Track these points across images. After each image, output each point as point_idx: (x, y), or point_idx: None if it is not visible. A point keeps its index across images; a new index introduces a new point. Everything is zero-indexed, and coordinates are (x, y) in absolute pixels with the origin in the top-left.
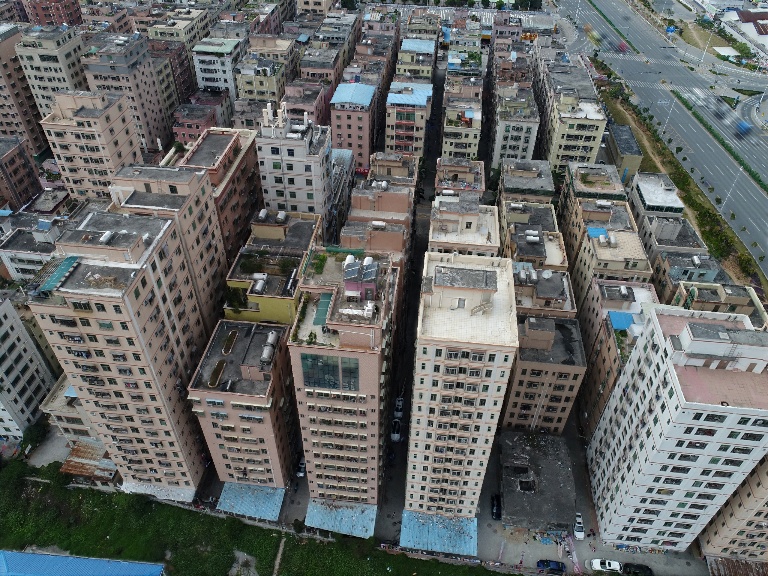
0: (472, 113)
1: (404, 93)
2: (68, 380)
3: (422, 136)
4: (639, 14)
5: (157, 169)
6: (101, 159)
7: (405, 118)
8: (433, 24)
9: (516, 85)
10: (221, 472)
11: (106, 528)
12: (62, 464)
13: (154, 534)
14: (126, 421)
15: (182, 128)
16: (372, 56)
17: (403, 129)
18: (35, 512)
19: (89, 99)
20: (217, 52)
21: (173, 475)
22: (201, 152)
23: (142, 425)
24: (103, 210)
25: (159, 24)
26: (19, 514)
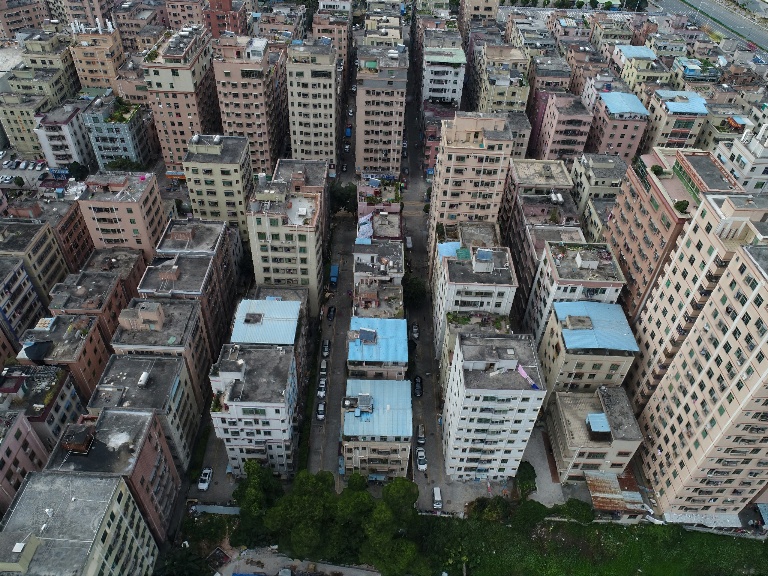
0: (741, 119)
1: (681, 101)
2: (567, 414)
3: (693, 143)
4: (738, 13)
5: (763, 198)
6: (493, 182)
7: (683, 126)
8: (624, 29)
9: (762, 90)
10: (766, 494)
11: (636, 561)
12: (580, 501)
13: (691, 563)
14: (748, 454)
15: (437, 142)
16: (594, 63)
17: (677, 137)
18: (554, 552)
19: (493, 121)
20: (454, 62)
21: (731, 502)
22: (699, 175)
23: (766, 456)
24: (483, 234)
25: (371, 33)
26: (537, 556)
